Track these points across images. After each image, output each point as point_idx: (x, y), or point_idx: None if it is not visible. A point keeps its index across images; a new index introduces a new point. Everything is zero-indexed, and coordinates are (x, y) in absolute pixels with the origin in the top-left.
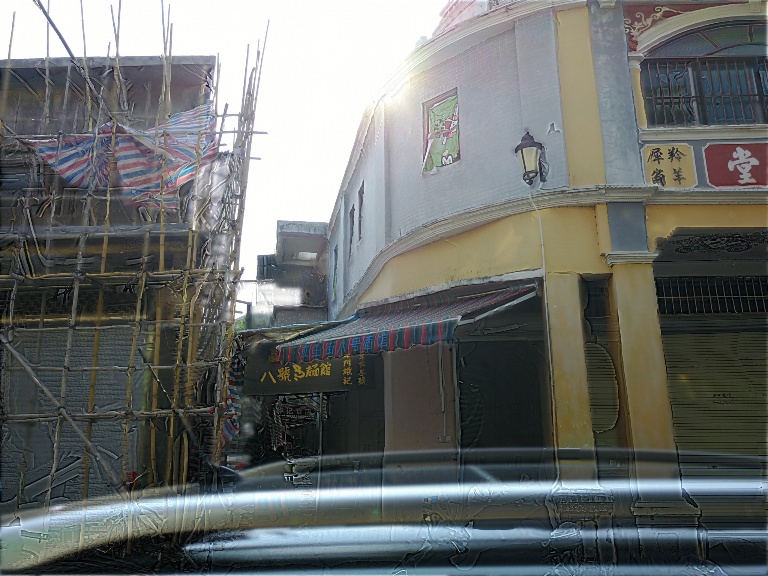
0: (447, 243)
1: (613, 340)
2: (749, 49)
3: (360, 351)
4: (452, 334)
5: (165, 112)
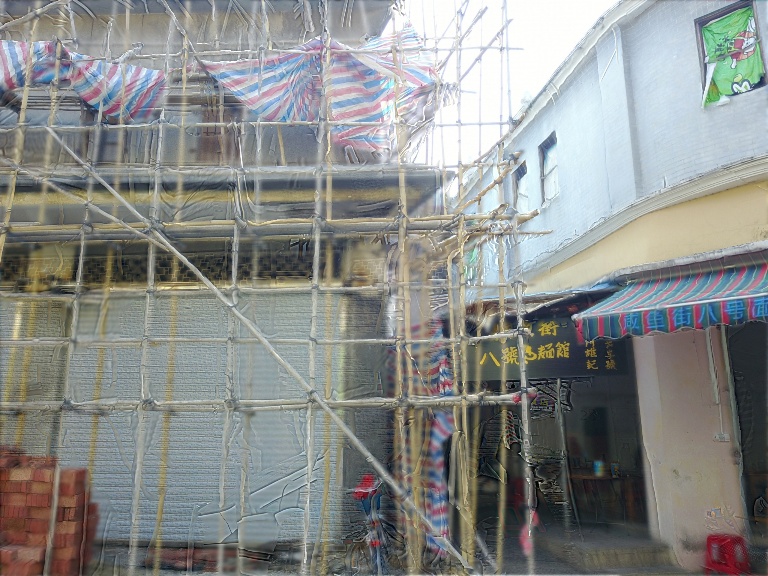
0: (752, 190)
1: None
2: None
3: (748, 319)
4: None
5: (344, 40)
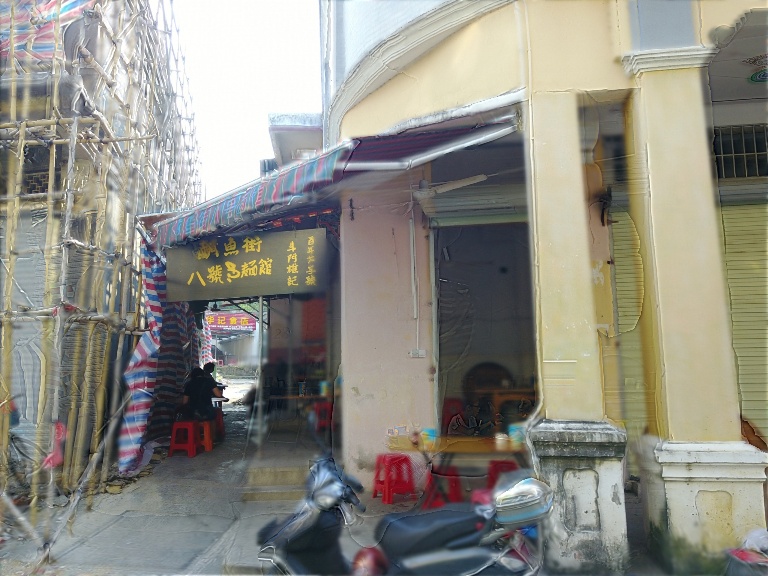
0: (406, 78)
1: (637, 192)
2: None
3: (233, 217)
4: (341, 171)
5: None
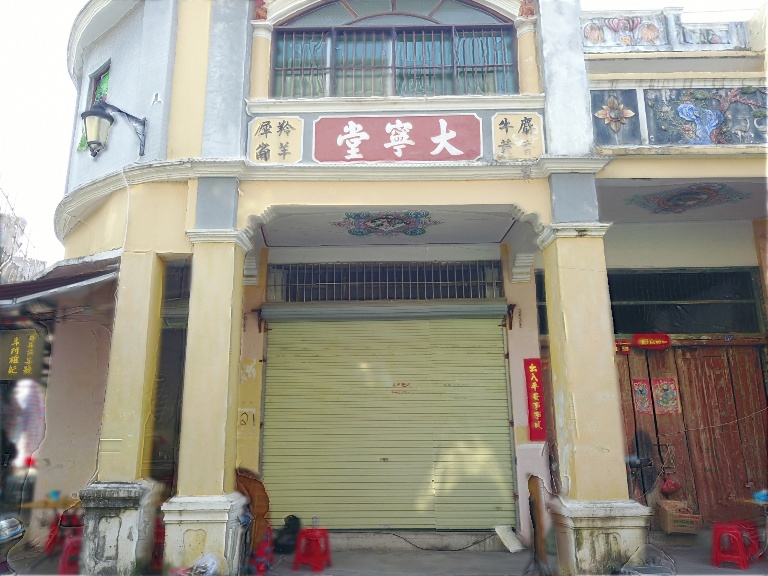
0: None
1: (179, 324)
2: (389, 19)
3: None
4: None
5: None
